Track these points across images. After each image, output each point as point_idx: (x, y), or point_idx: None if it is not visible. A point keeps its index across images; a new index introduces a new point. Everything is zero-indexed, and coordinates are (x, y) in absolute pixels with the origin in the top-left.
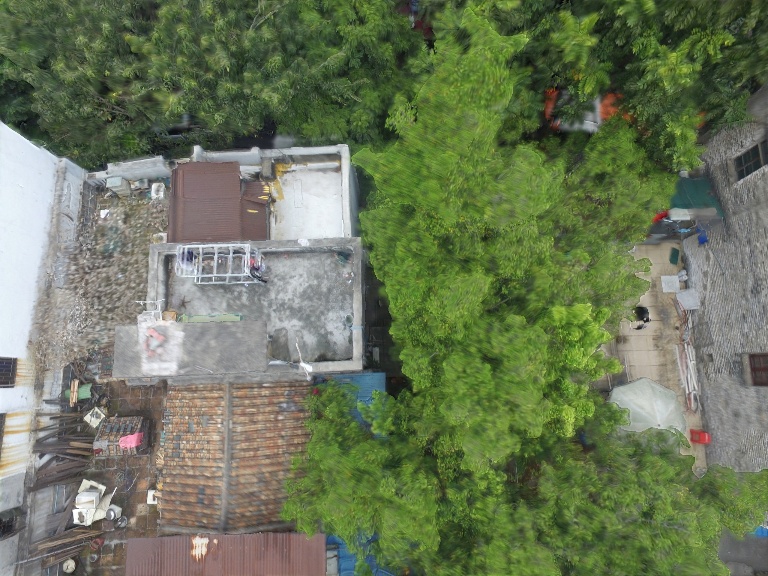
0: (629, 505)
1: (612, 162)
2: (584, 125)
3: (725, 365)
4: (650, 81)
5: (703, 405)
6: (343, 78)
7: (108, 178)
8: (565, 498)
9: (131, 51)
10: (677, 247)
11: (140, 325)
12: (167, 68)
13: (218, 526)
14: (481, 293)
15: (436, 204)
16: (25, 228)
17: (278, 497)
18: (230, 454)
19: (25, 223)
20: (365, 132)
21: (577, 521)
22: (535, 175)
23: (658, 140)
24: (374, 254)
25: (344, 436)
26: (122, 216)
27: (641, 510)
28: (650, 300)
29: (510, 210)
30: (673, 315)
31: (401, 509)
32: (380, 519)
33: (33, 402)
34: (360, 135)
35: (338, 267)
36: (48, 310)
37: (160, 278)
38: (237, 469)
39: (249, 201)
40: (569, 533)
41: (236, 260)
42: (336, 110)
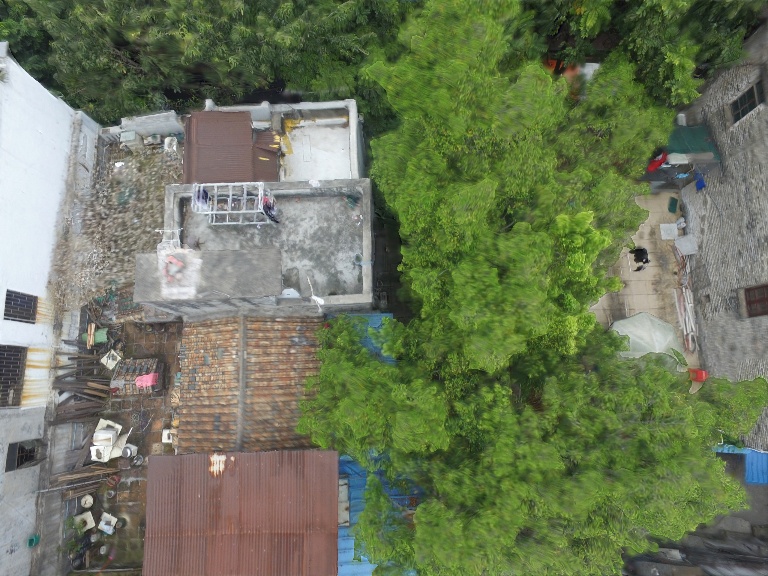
0: (629, 405)
1: (613, 95)
2: (586, 68)
3: (722, 303)
4: (649, 8)
5: (700, 345)
6: (351, 34)
7: (122, 132)
8: (568, 405)
9: (147, 0)
10: (675, 196)
11: (159, 253)
12: (184, 10)
13: (234, 449)
14: (489, 199)
15: (446, 113)
16: (44, 173)
17: (291, 425)
18: (245, 382)
19: (44, 168)
20: (372, 87)
21: (579, 424)
22: (540, 80)
23: (657, 74)
24: (385, 180)
25: (355, 362)
26: (137, 164)
27: (640, 411)
28: (649, 247)
29: (516, 117)
30: (672, 261)
31: (412, 410)
32: (390, 436)
33: (52, 341)
34: (367, 92)
35: (347, 210)
36: (66, 253)
37: (176, 219)
38: (252, 397)
39: (261, 149)
40: (572, 435)
41: (249, 204)
42: (344, 67)
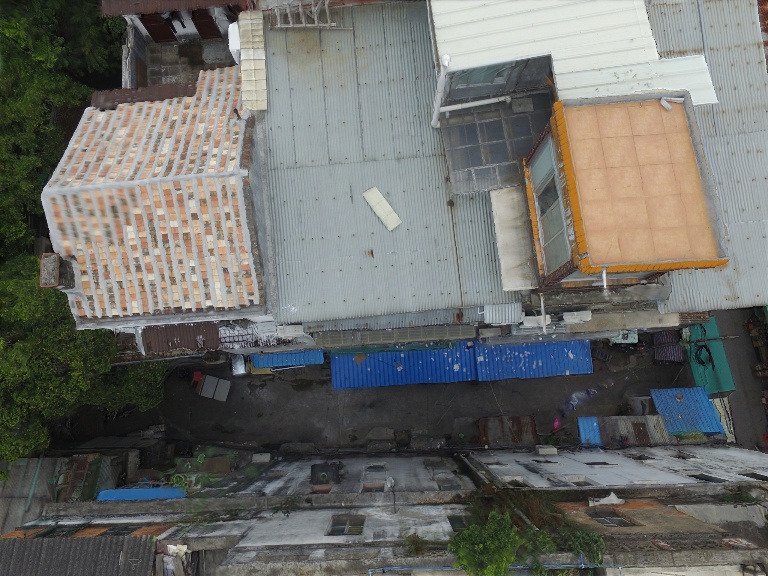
0: None
1: None
2: None
3: None
4: None
5: None
6: None
7: None
8: None
9: None
10: None
11: None
12: None
13: None
14: None
15: None
16: None
17: None
18: None
19: None
20: None
21: None
22: None
23: None
24: None
25: None
26: None
27: None
28: None
29: None
30: None
31: None
32: None
33: None
34: None
35: None
36: None
37: None
38: None
39: None
40: None
41: None
42: None
